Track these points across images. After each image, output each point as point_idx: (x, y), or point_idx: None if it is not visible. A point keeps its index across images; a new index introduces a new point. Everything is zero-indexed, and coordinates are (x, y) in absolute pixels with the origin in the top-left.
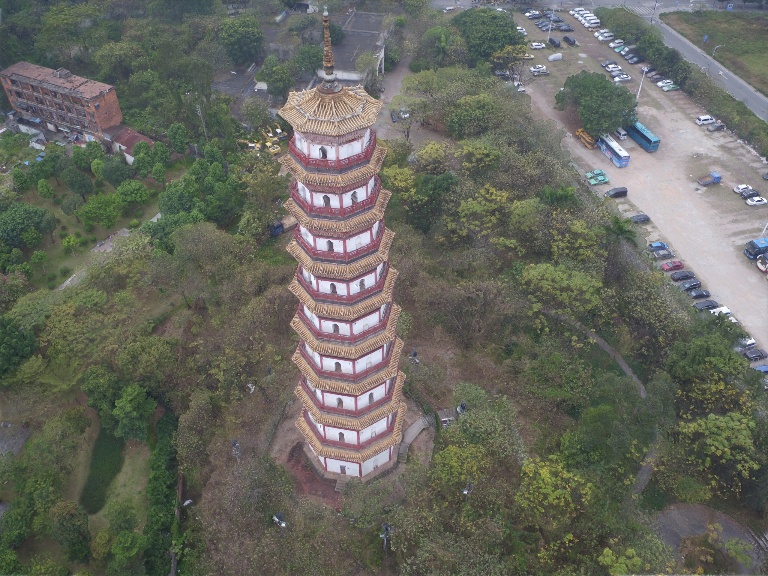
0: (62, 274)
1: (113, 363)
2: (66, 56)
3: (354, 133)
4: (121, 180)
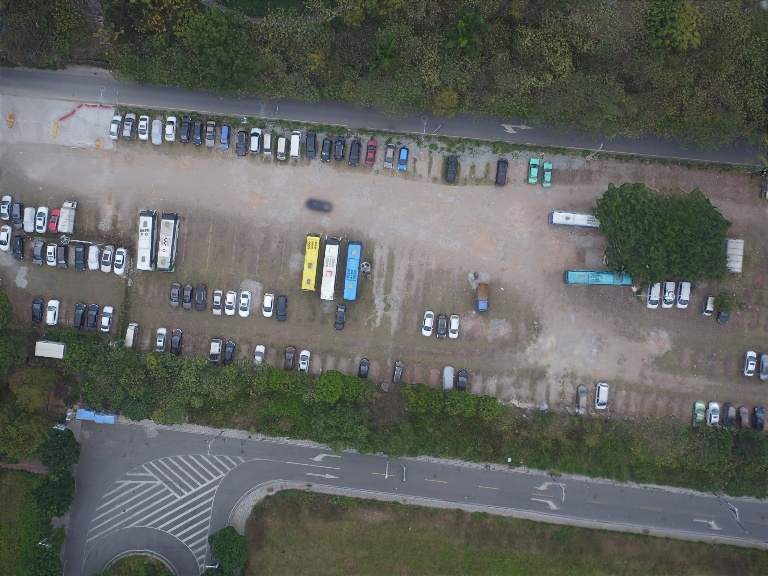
0: None
1: None
2: None
3: None
4: None
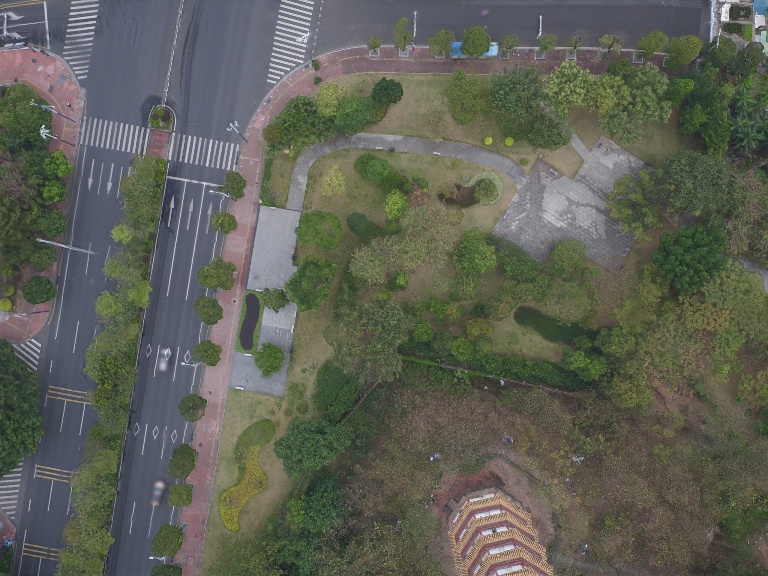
0: None
1: (635, 356)
2: None
3: None
4: None
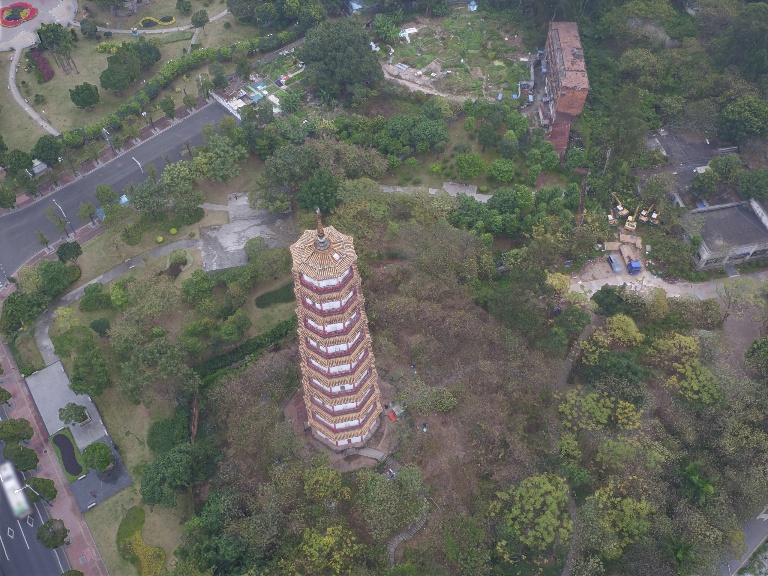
0: (414, 181)
1: None
2: (624, 34)
3: None
4: (507, 156)
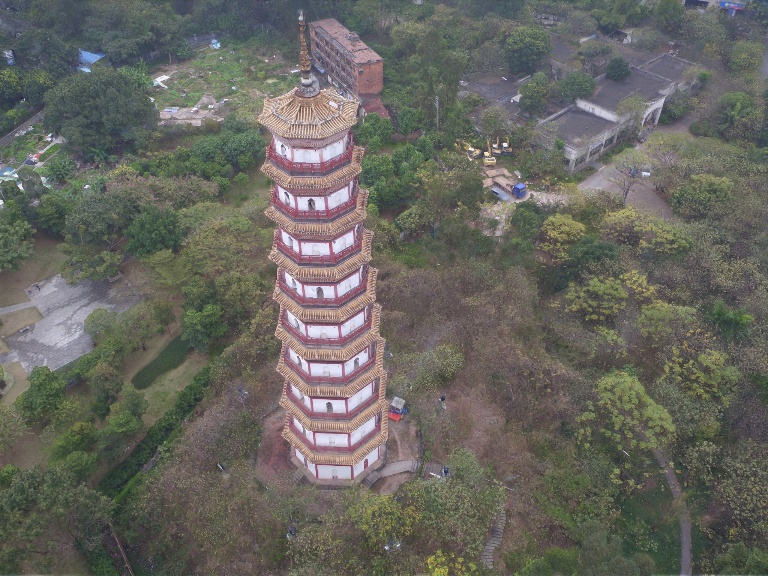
0: None
1: None
2: (377, 24)
3: (306, 141)
4: None
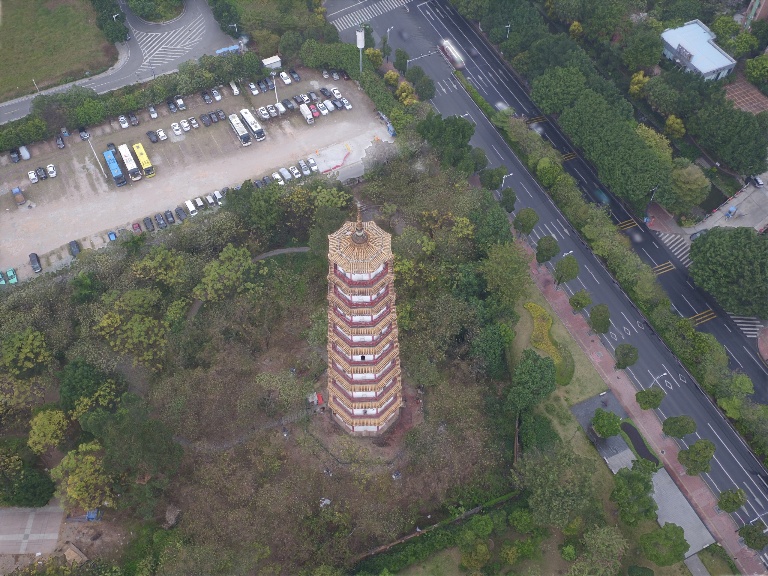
0: None
1: None
2: None
3: None
4: None
